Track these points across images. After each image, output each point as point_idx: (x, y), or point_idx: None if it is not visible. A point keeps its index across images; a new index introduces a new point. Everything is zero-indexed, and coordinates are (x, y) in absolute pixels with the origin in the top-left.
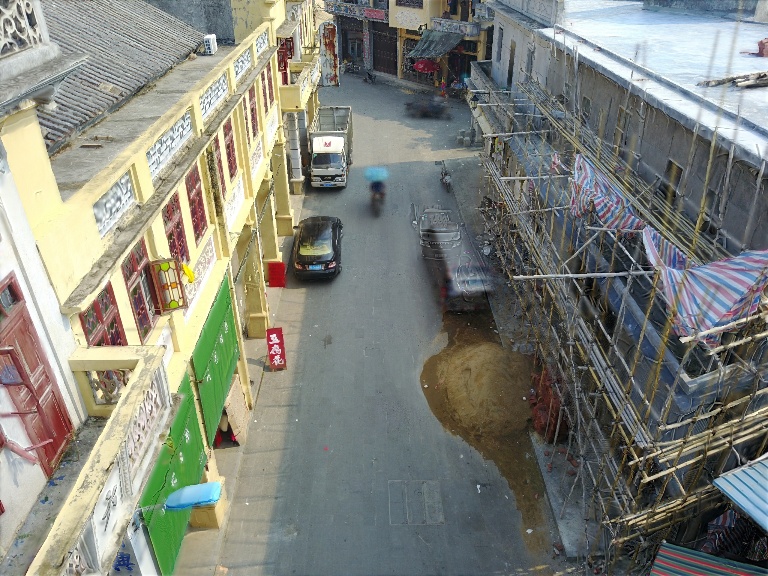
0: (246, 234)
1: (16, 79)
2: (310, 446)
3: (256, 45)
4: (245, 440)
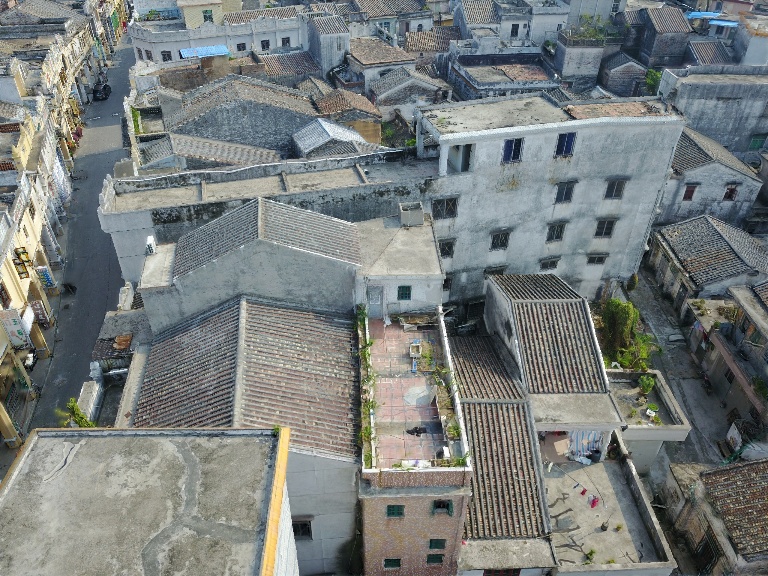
0: (117, 9)
1: None
2: None
3: None
4: None
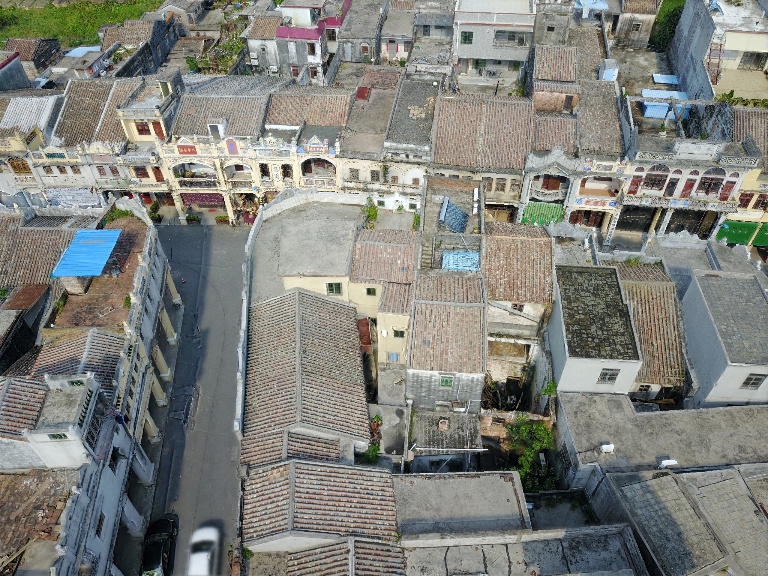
0: None
1: None
2: None
3: None
4: (767, 264)
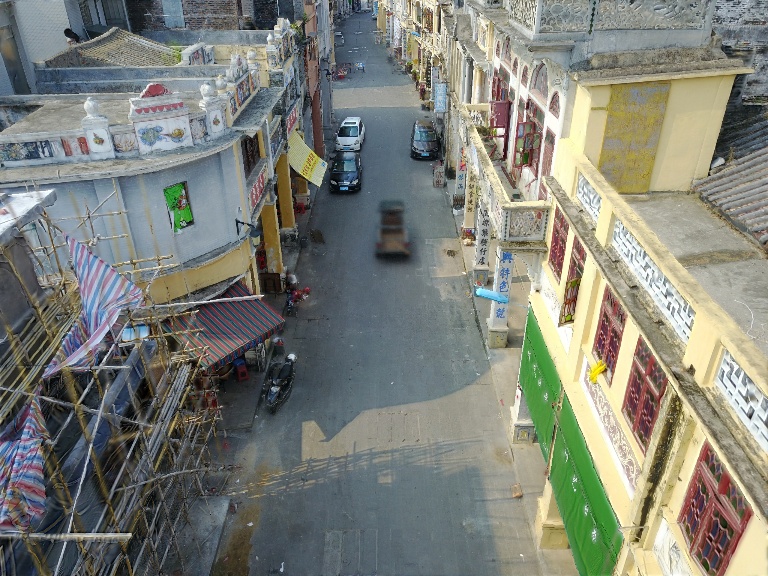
0: None
1: None
2: None
3: None
4: None
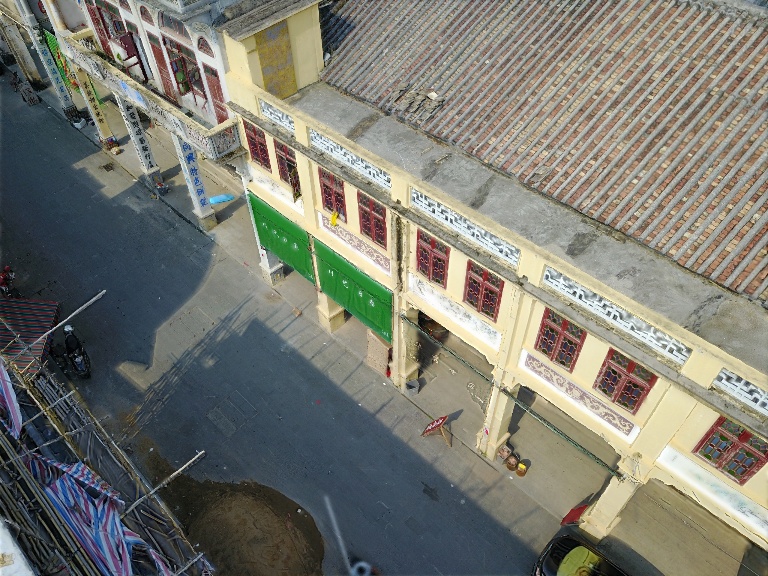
0: None
1: (161, 5)
2: (330, 396)
3: (763, 396)
4: (368, 364)
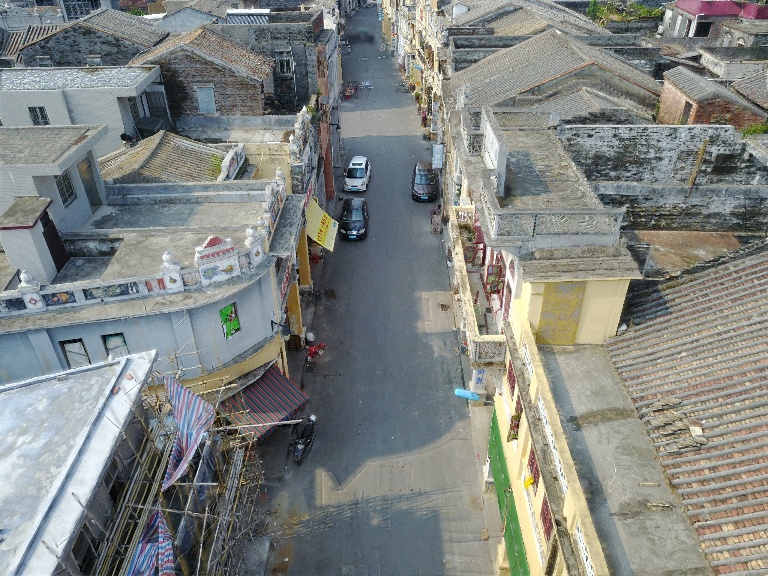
0: None
1: None
2: None
3: None
4: None
